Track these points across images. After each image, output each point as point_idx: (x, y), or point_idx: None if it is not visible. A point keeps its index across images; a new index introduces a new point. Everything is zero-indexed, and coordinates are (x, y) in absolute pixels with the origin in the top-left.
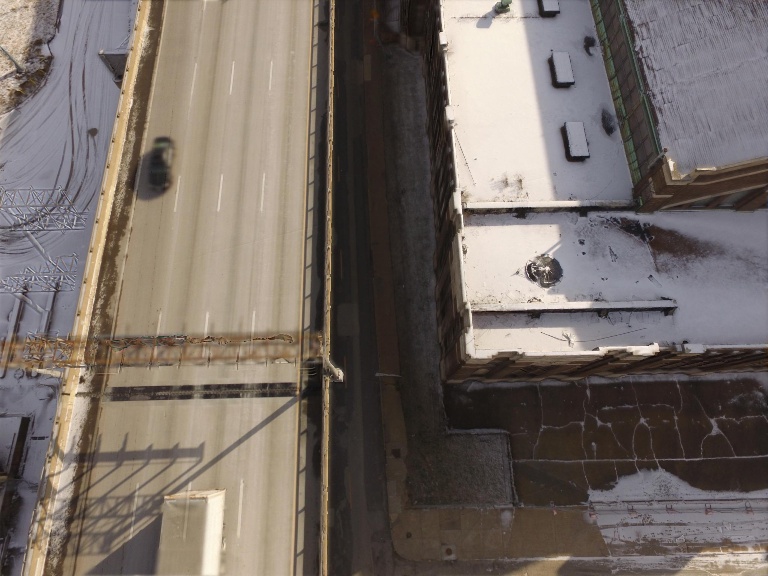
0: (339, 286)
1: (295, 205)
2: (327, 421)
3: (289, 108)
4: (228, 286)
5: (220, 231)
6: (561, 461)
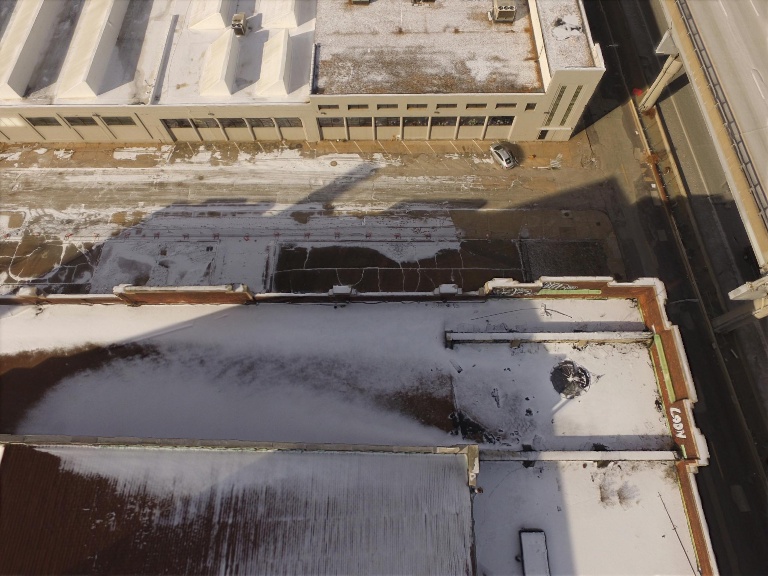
0: (712, 433)
1: None
2: (766, 235)
3: None
4: None
5: None
6: (481, 269)
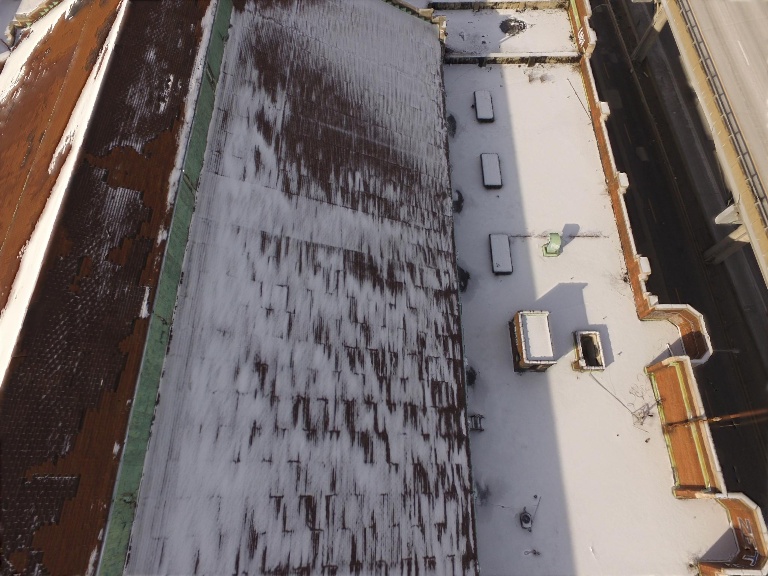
0: (625, 119)
1: (714, 45)
2: None
3: (753, 114)
4: (740, 0)
5: (763, 30)
6: None
